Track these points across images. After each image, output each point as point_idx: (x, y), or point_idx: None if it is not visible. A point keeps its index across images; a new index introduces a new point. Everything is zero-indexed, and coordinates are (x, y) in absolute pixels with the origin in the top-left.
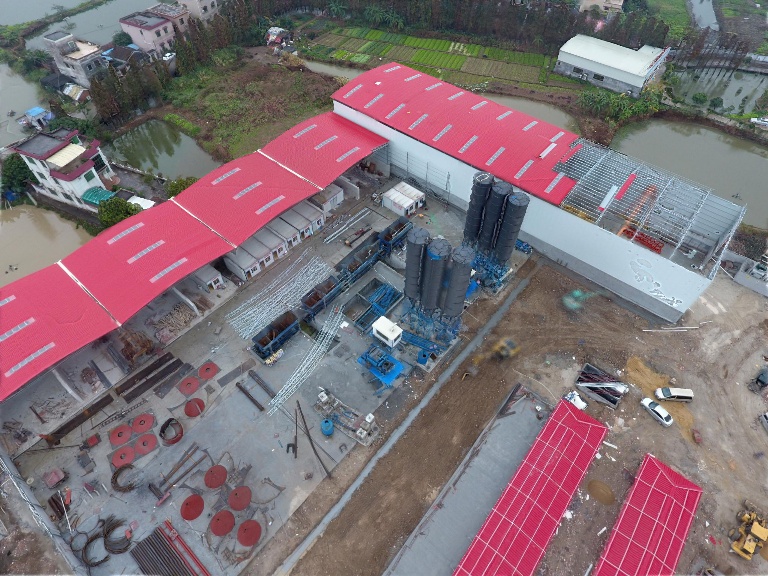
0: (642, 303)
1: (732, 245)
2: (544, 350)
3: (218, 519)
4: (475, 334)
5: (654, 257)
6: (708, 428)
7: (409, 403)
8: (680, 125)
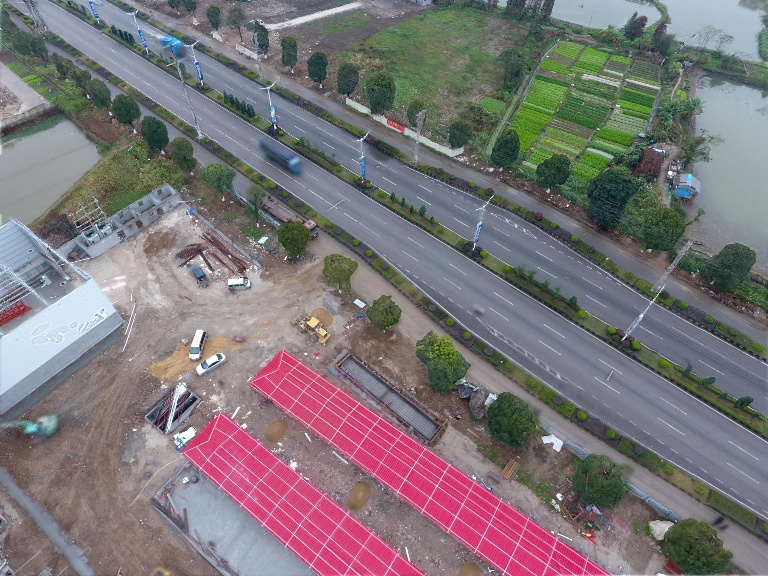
0: (89, 344)
1: (51, 244)
2: (114, 463)
3: None
4: (61, 558)
5: (38, 319)
6: (233, 328)
7: None
8: None
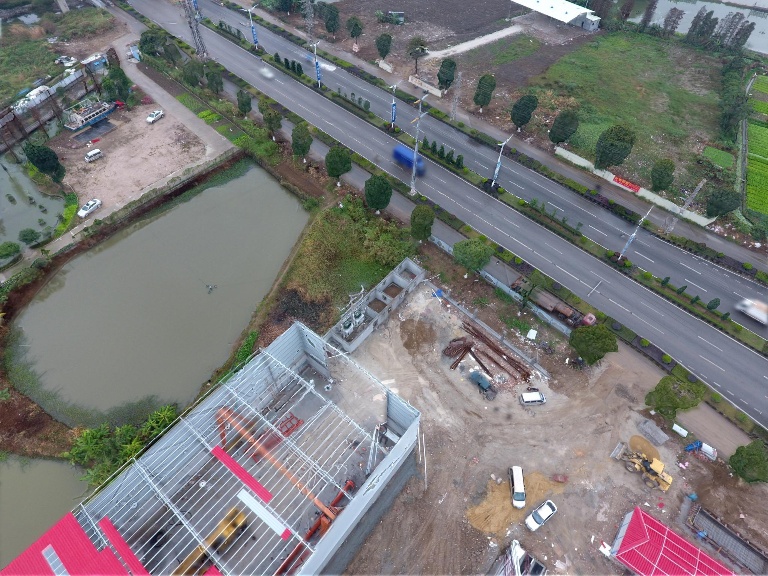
0: None
1: None
2: None
3: None
4: None
5: None
6: (544, 461)
7: None
8: (41, 290)
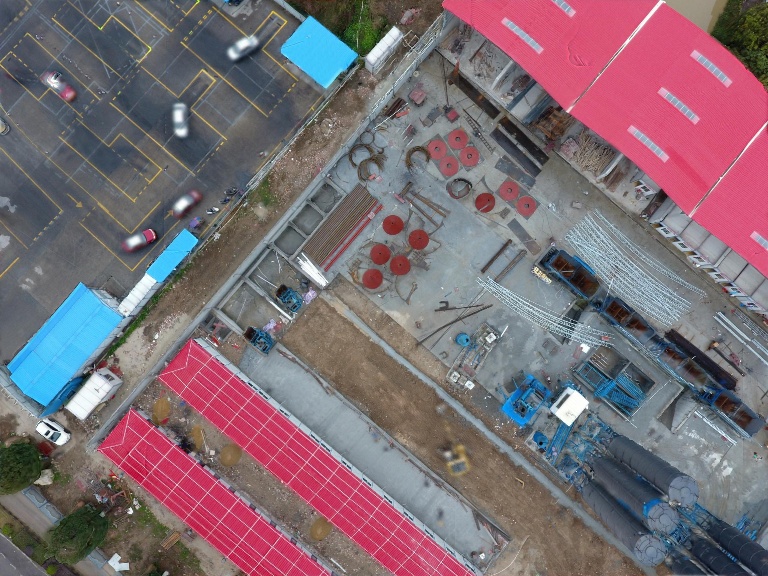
0: None
1: None
2: (553, 575)
3: (380, 253)
4: (574, 499)
5: None
6: None
7: (490, 420)
8: None
